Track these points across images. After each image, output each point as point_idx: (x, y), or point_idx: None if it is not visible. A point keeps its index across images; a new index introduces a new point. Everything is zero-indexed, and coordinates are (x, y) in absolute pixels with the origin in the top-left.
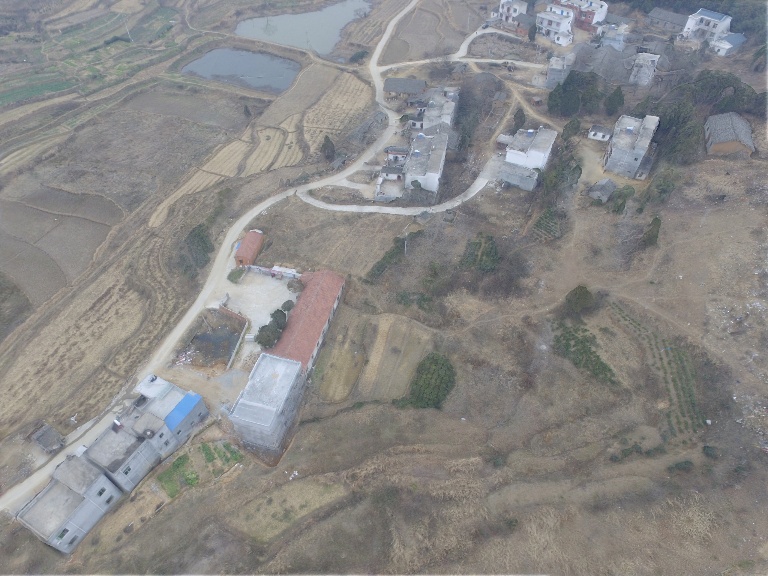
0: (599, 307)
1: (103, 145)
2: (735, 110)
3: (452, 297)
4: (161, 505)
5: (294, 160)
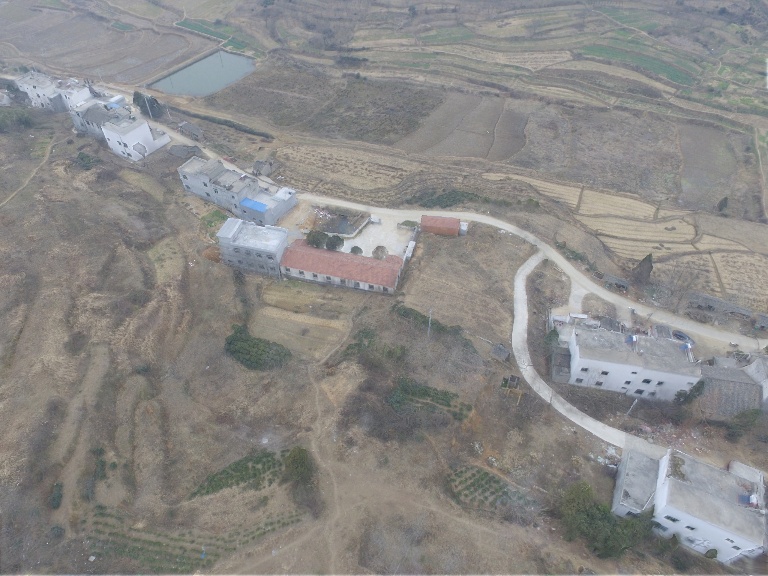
0: None
1: (601, 127)
2: None
3: (355, 368)
4: (197, 214)
5: (630, 254)
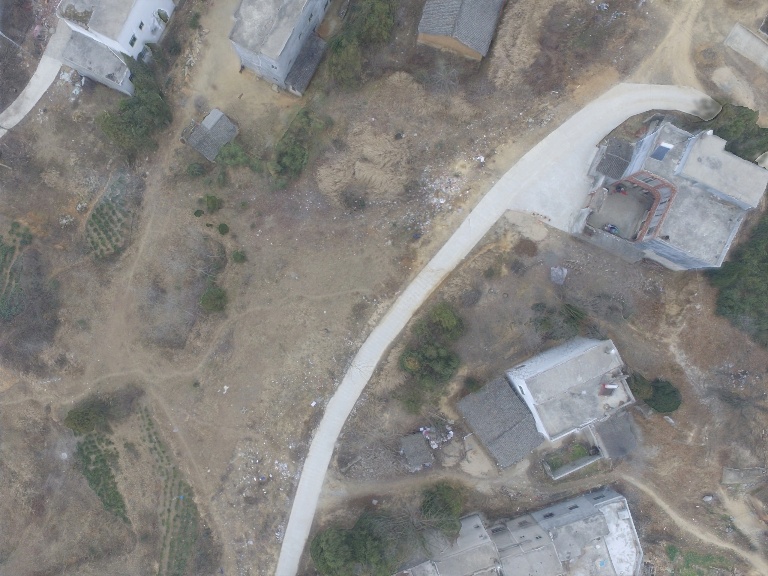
0: (128, 412)
1: None
2: None
3: None
4: None
5: None
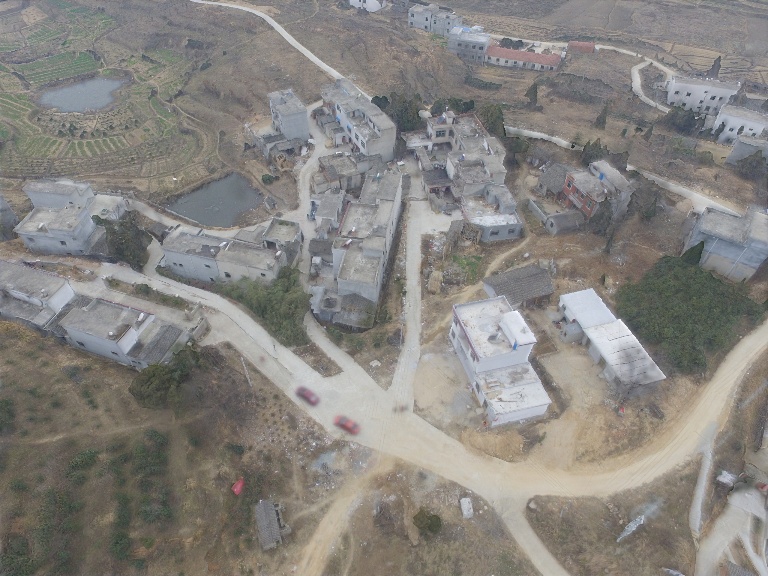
0: (532, 111)
1: None
2: None
3: (543, 88)
4: None
5: None
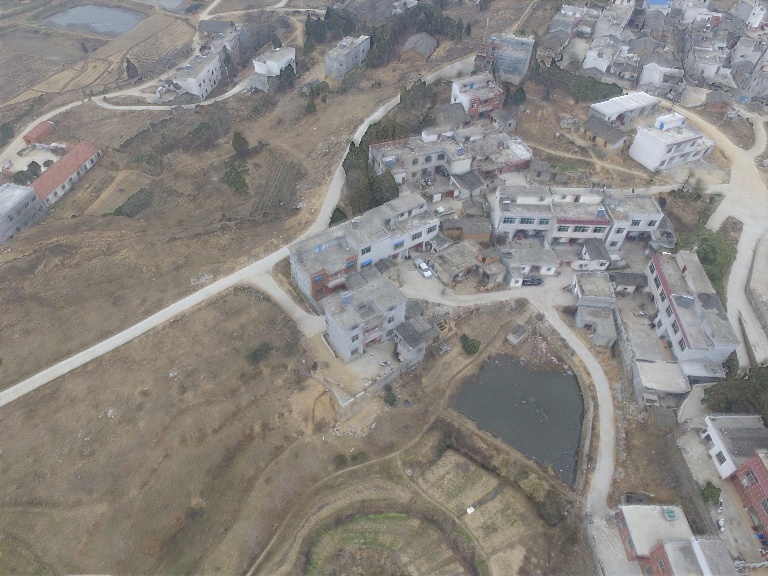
0: (259, 152)
1: None
2: (426, 31)
3: (170, 155)
4: None
5: (109, 81)
